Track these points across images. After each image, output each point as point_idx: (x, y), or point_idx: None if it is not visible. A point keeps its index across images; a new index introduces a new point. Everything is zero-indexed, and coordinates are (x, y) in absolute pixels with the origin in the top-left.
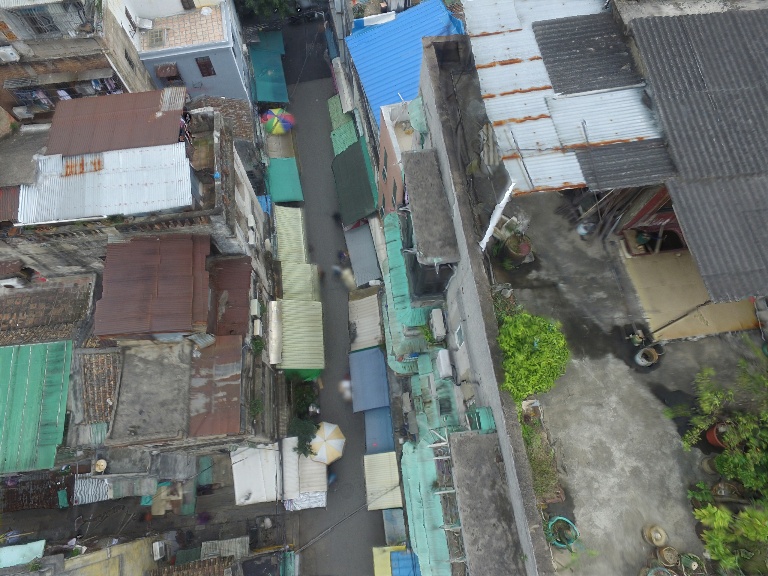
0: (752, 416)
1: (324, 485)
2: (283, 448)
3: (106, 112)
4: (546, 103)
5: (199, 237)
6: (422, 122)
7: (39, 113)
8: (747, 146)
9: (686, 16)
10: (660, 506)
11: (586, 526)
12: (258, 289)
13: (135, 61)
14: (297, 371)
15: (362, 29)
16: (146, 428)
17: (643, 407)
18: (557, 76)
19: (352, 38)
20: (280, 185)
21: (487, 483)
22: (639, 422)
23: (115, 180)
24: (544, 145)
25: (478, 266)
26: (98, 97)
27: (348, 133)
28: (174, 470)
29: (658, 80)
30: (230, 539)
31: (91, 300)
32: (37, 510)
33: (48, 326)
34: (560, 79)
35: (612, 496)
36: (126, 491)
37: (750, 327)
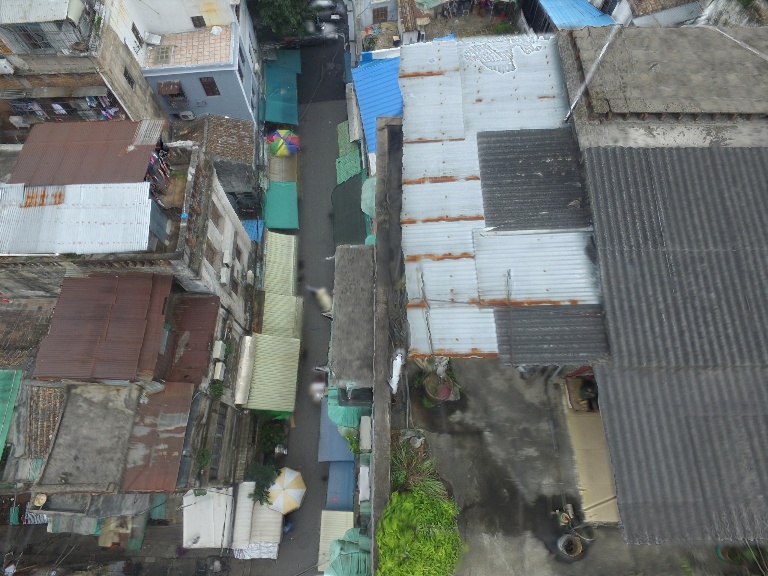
0: None
1: (277, 536)
2: (239, 492)
3: (79, 141)
4: (472, 239)
5: (161, 277)
6: (372, 207)
7: None
8: (705, 328)
9: (654, 149)
10: None
11: None
12: (227, 328)
13: (136, 78)
14: (265, 411)
15: (370, 62)
16: (78, 476)
17: None
18: (492, 204)
19: (359, 71)
20: (277, 210)
21: None
22: None
23: (73, 216)
24: (459, 294)
25: (382, 412)
26: (74, 124)
27: (353, 162)
28: (120, 507)
29: (605, 230)
30: None
31: None
32: None
33: (4, 350)
34: (495, 209)
35: None
36: (65, 527)
37: None
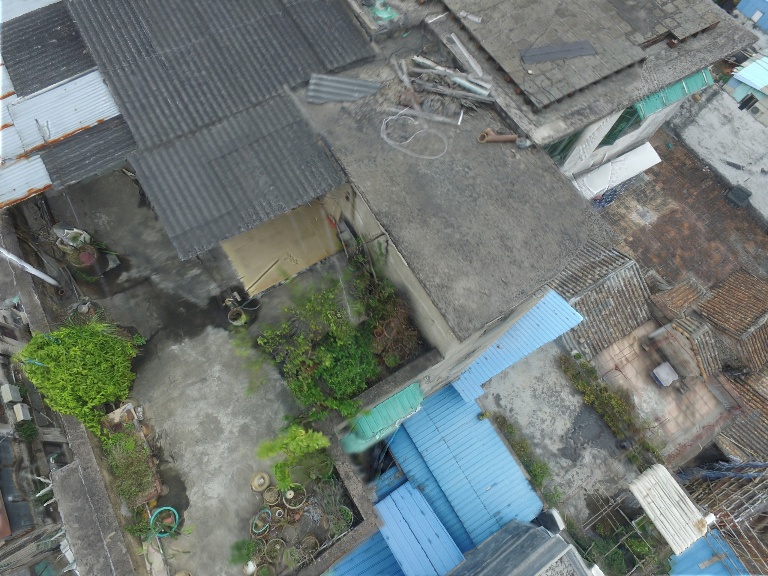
0: None
1: None
2: None
3: None
4: (8, 111)
5: None
6: None
7: None
8: (204, 97)
9: None
10: (268, 451)
11: (200, 502)
12: (12, 371)
13: None
14: None
15: None
16: None
17: (245, 364)
18: (19, 79)
19: None
20: None
21: None
22: (243, 380)
23: None
24: (6, 157)
25: (28, 295)
26: None
27: None
28: None
29: (103, 57)
30: None
31: None
32: None
33: None
34: (22, 82)
35: (223, 462)
36: None
37: (335, 251)
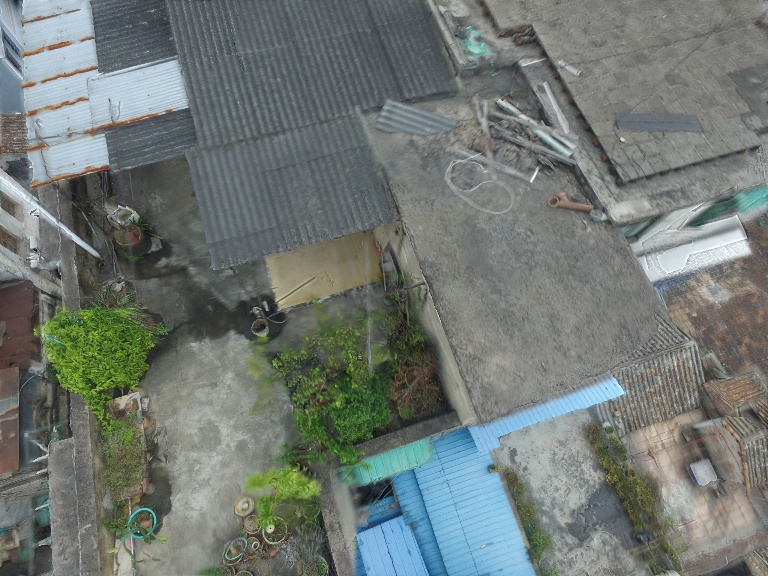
0: (309, 372)
1: None
2: None
3: None
4: (87, 85)
5: None
6: None
7: None
8: (274, 105)
9: None
10: (260, 475)
11: (181, 511)
12: None
13: None
14: None
15: None
16: None
17: (258, 378)
18: (105, 55)
19: None
20: None
21: None
22: (252, 394)
23: None
24: (74, 130)
25: (68, 265)
26: None
27: None
28: None
29: (186, 48)
30: None
31: None
32: None
33: None
34: (106, 58)
35: (213, 474)
36: None
37: (374, 280)
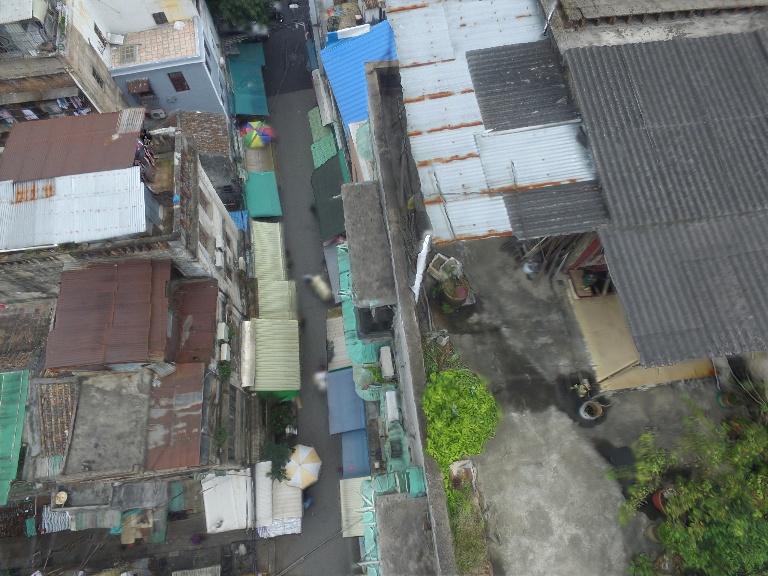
0: (695, 485)
1: (299, 511)
2: (256, 473)
3: (61, 135)
4: (475, 141)
5: (159, 262)
6: (368, 150)
7: (6, 132)
8: (688, 188)
9: (626, 45)
10: None
11: None
12: (227, 311)
13: (104, 78)
14: (272, 392)
15: (336, 42)
16: (101, 463)
17: (586, 466)
18: (489, 111)
19: (326, 51)
20: (258, 200)
21: (413, 554)
22: (581, 483)
23: (67, 207)
24: (470, 188)
25: (409, 314)
26: None
27: (328, 146)
28: (141, 499)
29: (592, 116)
30: (201, 568)
31: (52, 326)
32: (8, 537)
33: (6, 354)
34: (491, 114)
35: (548, 568)
36: (89, 523)
37: (705, 375)
